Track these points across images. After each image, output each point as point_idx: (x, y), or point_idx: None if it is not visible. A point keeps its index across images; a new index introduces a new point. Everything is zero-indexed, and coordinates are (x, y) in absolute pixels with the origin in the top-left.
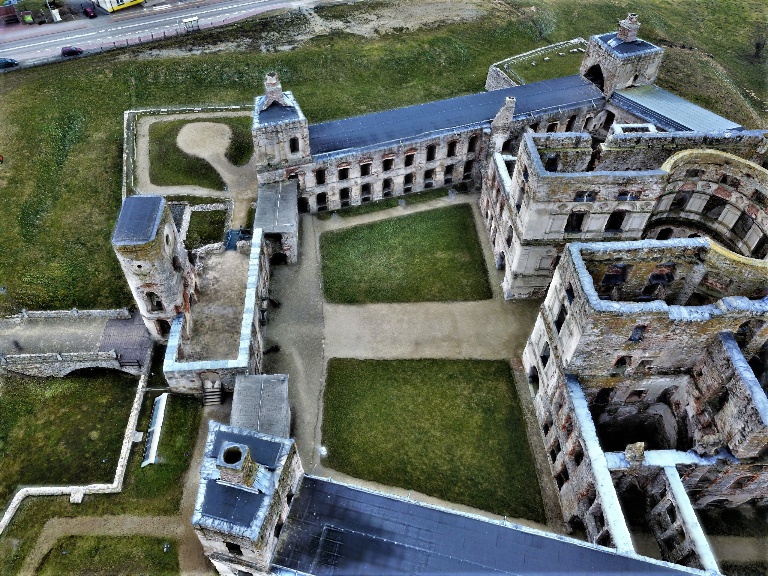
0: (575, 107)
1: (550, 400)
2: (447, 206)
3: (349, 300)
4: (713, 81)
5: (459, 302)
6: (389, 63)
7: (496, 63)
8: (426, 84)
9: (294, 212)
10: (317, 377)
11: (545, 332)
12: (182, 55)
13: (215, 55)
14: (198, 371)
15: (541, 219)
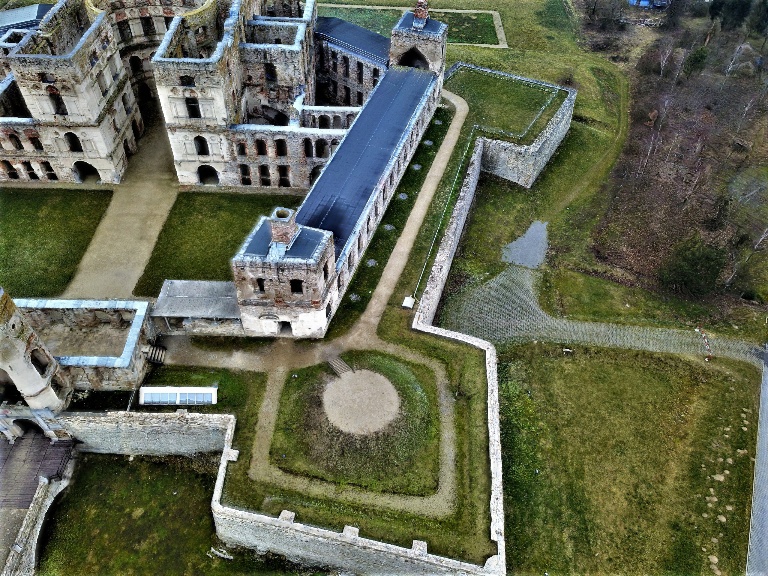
0: None
1: (233, 160)
2: None
3: (66, 279)
4: None
5: (108, 209)
6: None
7: None
8: None
9: None
10: None
11: (188, 135)
12: None
13: None
14: (138, 340)
15: (91, 96)
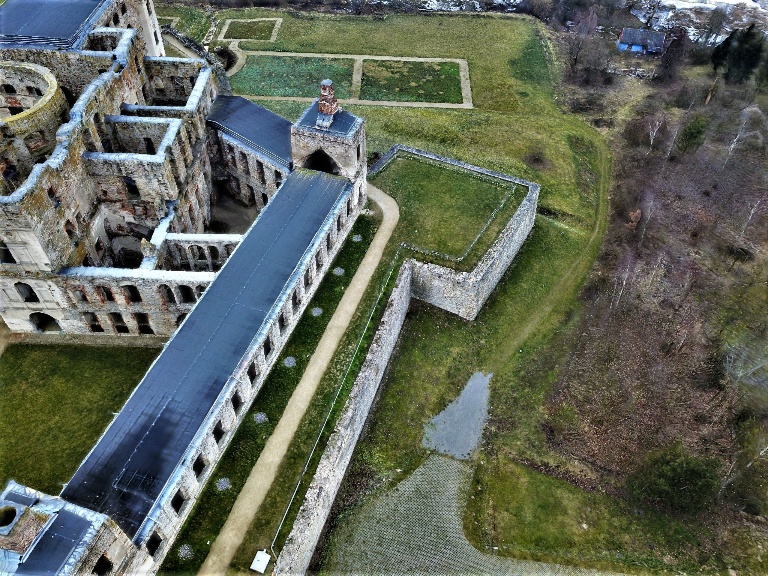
0: None
1: (72, 307)
2: None
3: None
4: None
5: None
6: None
7: None
8: None
9: None
10: None
11: (4, 281)
12: None
13: None
14: None
15: None
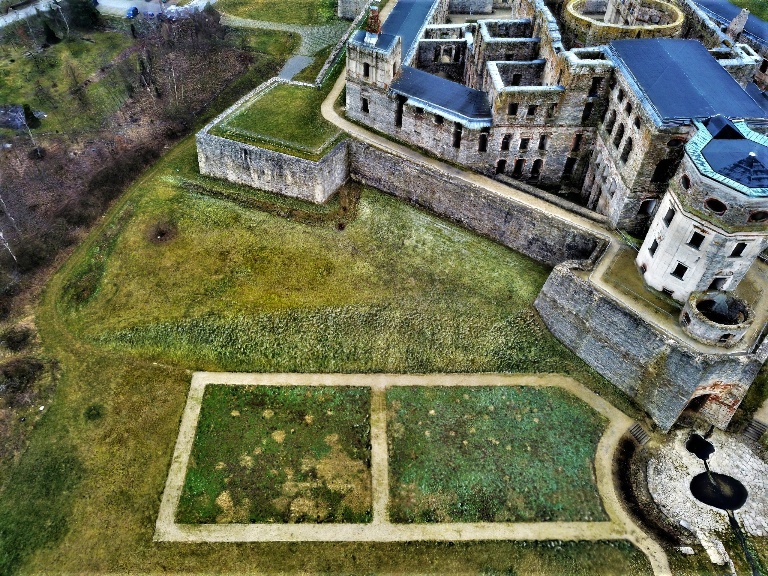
0: None
1: None
2: None
3: None
4: None
5: None
6: None
7: None
8: None
9: None
10: None
11: None
12: None
13: None
14: None
15: (610, 7)
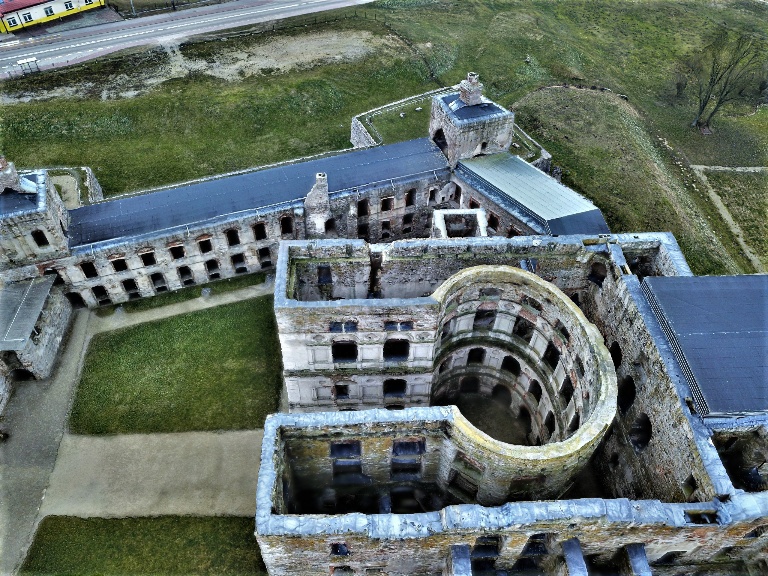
0: (412, 180)
1: None
2: (258, 297)
3: (97, 430)
4: (616, 130)
5: (233, 432)
6: (246, 111)
7: (359, 114)
8: (284, 136)
9: (33, 322)
10: (19, 545)
11: None
12: (8, 103)
13: (45, 103)
14: None
15: (297, 350)
